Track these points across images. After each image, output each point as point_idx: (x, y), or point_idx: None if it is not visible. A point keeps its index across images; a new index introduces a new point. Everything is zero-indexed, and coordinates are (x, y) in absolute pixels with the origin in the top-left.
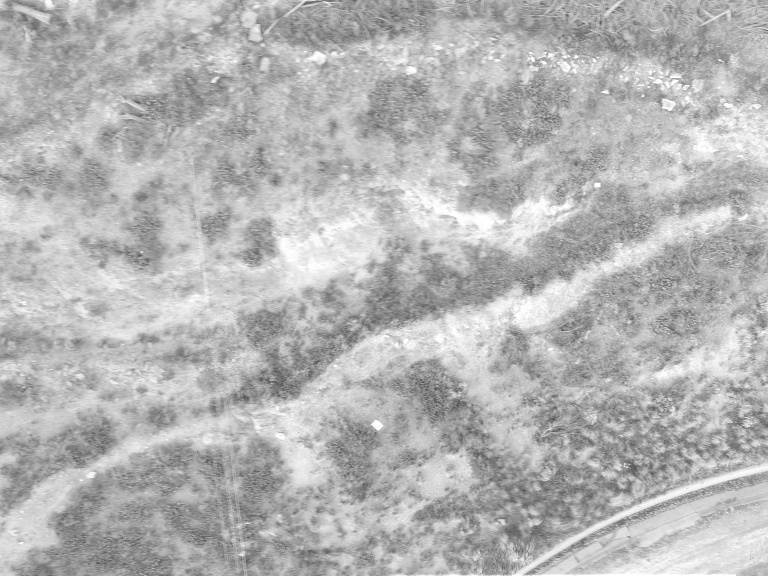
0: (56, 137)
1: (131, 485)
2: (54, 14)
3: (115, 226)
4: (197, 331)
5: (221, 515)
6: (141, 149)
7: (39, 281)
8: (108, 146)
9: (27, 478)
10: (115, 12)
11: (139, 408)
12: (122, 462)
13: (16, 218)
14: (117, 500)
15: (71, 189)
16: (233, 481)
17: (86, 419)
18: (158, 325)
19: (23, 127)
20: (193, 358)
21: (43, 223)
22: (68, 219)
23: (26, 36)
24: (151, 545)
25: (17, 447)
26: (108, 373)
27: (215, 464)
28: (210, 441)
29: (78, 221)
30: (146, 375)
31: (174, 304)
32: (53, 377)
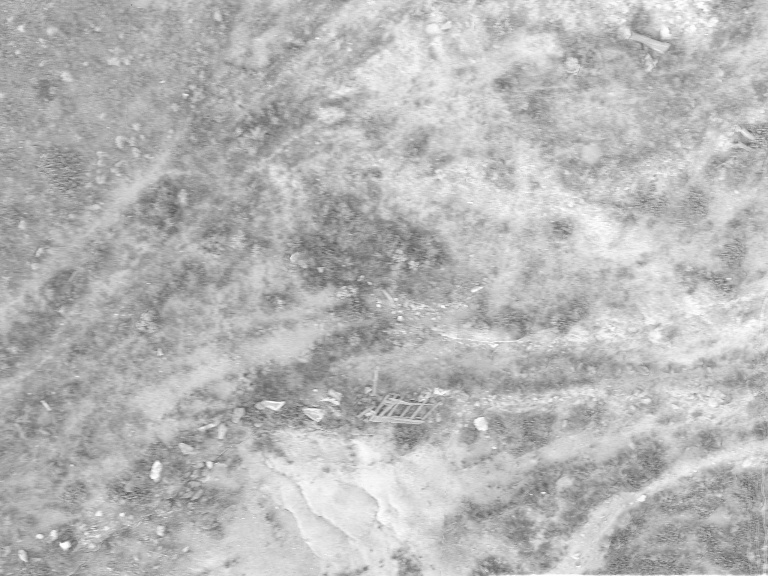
0: (671, 165)
1: (671, 508)
2: (671, 43)
3: (705, 253)
4: (750, 356)
5: (749, 537)
6: (744, 177)
7: (631, 307)
8: (713, 174)
9: (584, 502)
10: (730, 42)
11: (689, 432)
12: (669, 485)
13: (614, 245)
14: (655, 523)
15: (674, 216)
16: (764, 504)
17: (639, 443)
18: (716, 350)
19: (641, 155)
20: (750, 383)
21: (640, 250)
22: (664, 246)
23: (649, 65)
24: (683, 567)
25: (576, 471)
26: (670, 398)
27: (749, 487)
28: (749, 464)
29: (673, 248)
30: (707, 400)
31: (732, 329)
32: (620, 402)
